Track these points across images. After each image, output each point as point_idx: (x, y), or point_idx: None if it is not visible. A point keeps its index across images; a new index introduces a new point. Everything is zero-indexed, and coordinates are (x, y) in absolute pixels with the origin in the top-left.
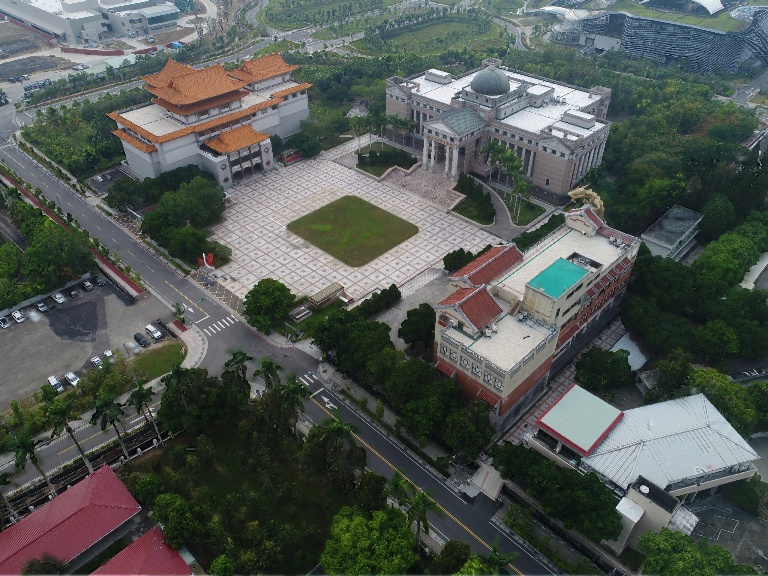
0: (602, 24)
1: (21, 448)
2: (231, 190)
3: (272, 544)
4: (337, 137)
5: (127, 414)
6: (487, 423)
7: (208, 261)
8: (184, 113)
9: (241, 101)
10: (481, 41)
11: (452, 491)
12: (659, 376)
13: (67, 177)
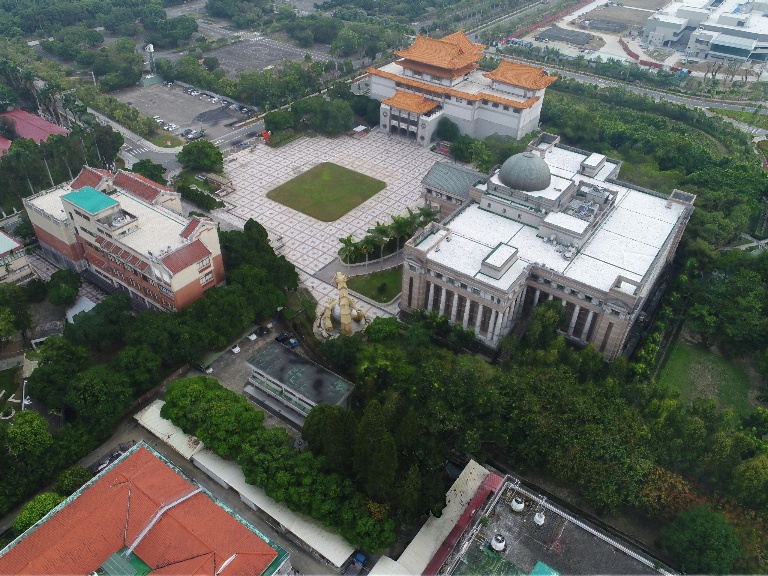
0: None
1: None
2: (380, 135)
3: None
4: (495, 163)
5: None
6: (32, 230)
7: None
8: (398, 63)
9: (463, 86)
10: None
11: None
12: None
13: None
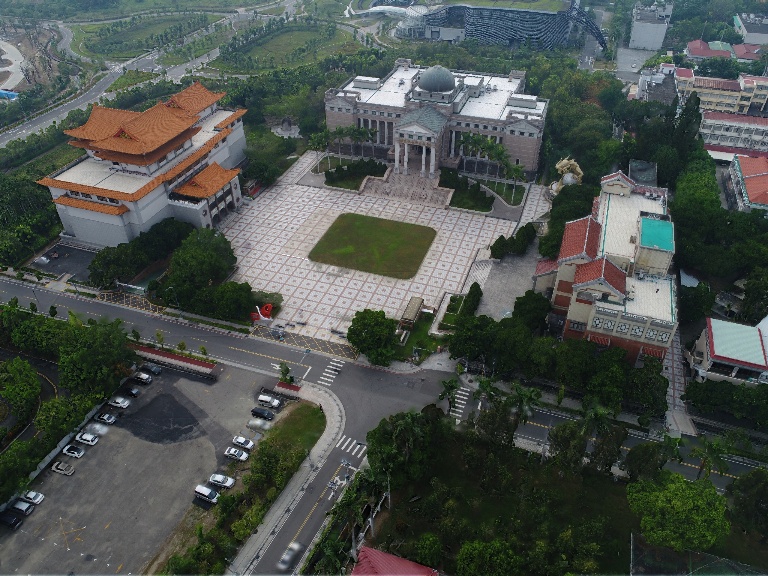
0: (443, 17)
1: (332, 556)
2: None
3: (595, 544)
4: (286, 160)
5: (317, 492)
6: (659, 374)
7: (262, 313)
8: (149, 162)
9: None
10: (338, 46)
11: None
12: (751, 293)
13: (3, 267)
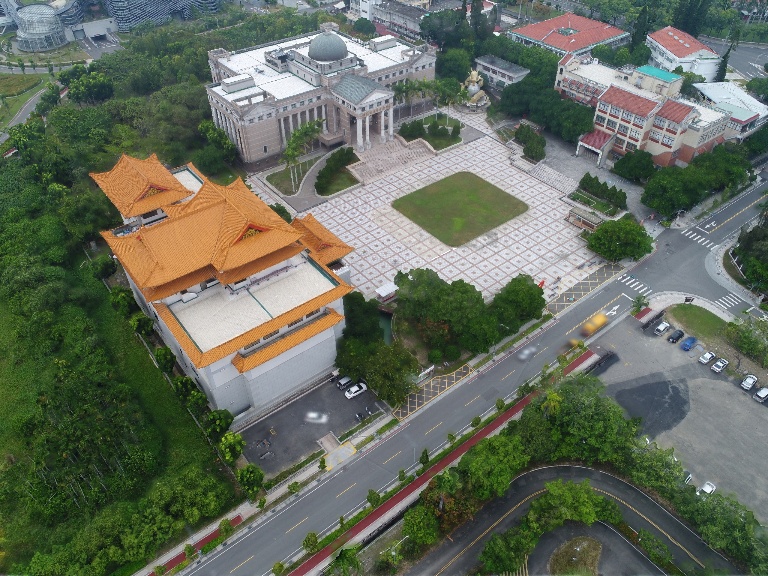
0: (78, 11)
1: None
2: None
3: None
4: None
5: None
6: None
7: None
8: None
9: None
10: None
11: (761, 184)
12: (683, 90)
13: None
